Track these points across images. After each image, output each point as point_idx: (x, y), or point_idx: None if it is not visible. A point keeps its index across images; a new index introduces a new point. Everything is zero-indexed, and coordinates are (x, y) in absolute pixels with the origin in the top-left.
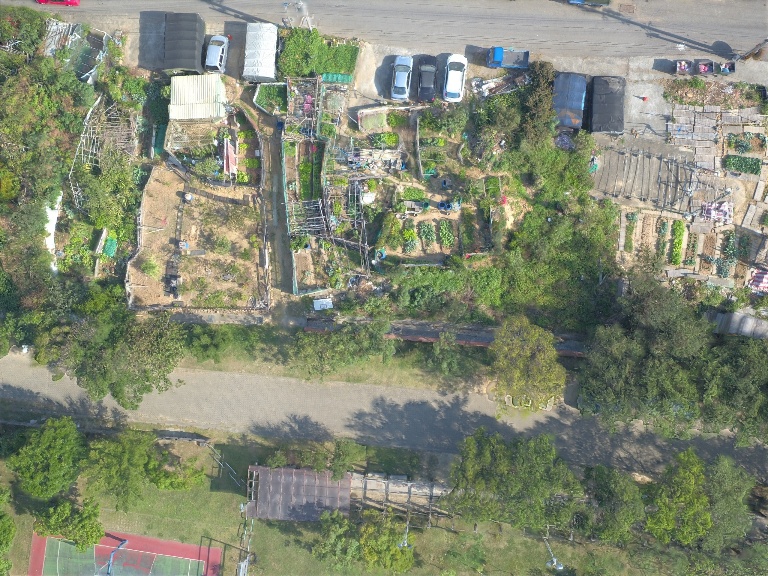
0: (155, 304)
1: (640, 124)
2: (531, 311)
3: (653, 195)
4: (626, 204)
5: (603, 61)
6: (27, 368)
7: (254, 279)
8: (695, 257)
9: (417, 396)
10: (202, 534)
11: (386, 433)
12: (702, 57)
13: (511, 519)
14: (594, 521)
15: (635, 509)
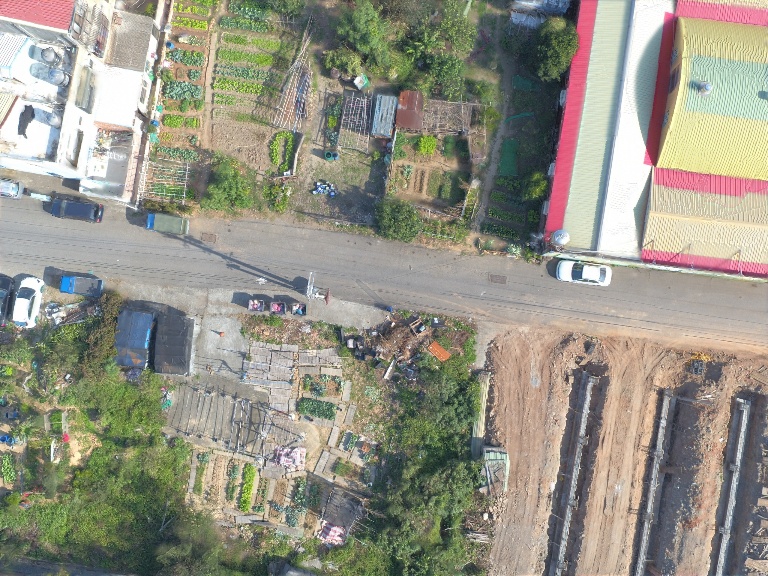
0: None
1: (216, 360)
2: (97, 551)
3: (226, 435)
4: (198, 443)
5: (182, 291)
6: None
7: None
8: (265, 503)
9: None
10: None
11: None
12: (282, 293)
13: None
14: None
15: None
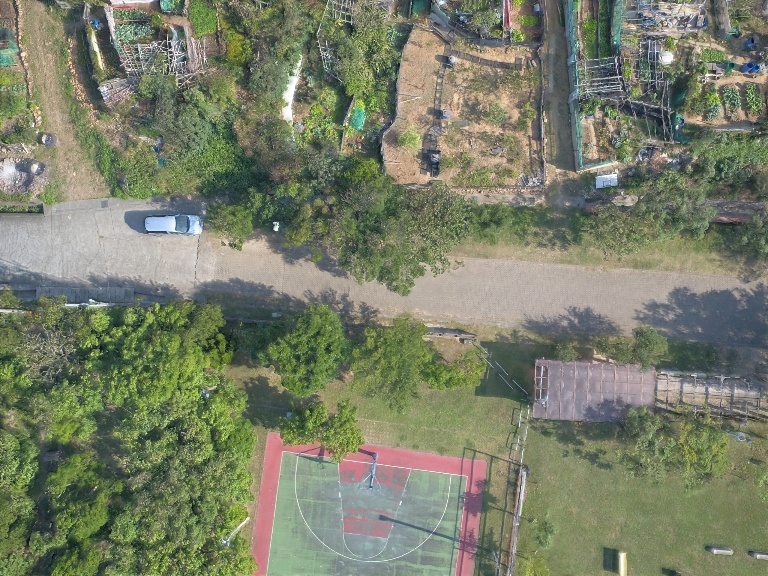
0: (409, 183)
1: None
2: None
3: None
4: None
5: None
6: (257, 258)
7: (526, 154)
8: None
9: (715, 284)
10: (465, 445)
11: (680, 326)
12: None
13: None
14: None
15: None
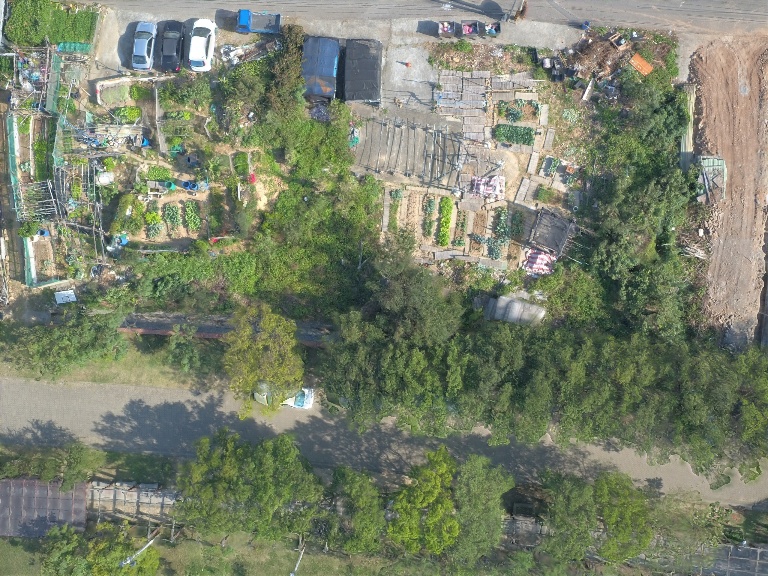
0: None
1: (404, 92)
2: (289, 300)
3: (419, 170)
4: (390, 180)
5: (364, 24)
6: None
7: None
8: (464, 237)
9: (168, 396)
10: None
11: (135, 437)
12: (470, 18)
13: (251, 530)
14: (335, 531)
15: (373, 517)
